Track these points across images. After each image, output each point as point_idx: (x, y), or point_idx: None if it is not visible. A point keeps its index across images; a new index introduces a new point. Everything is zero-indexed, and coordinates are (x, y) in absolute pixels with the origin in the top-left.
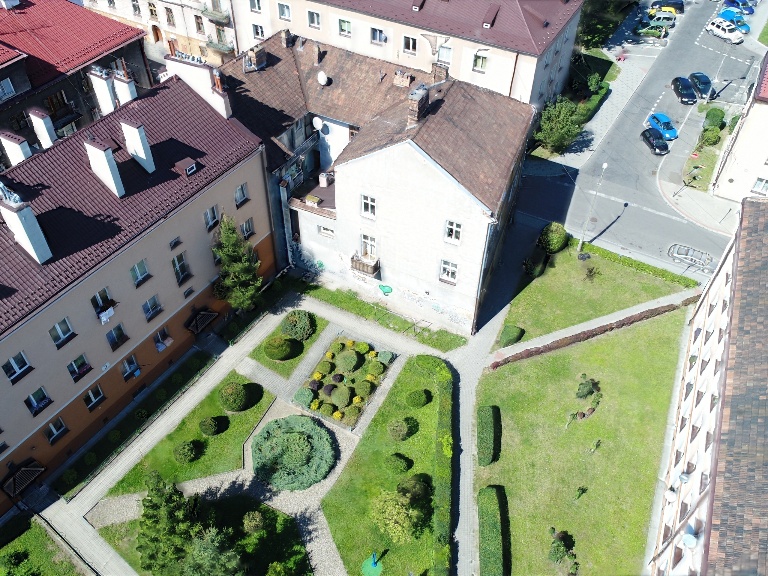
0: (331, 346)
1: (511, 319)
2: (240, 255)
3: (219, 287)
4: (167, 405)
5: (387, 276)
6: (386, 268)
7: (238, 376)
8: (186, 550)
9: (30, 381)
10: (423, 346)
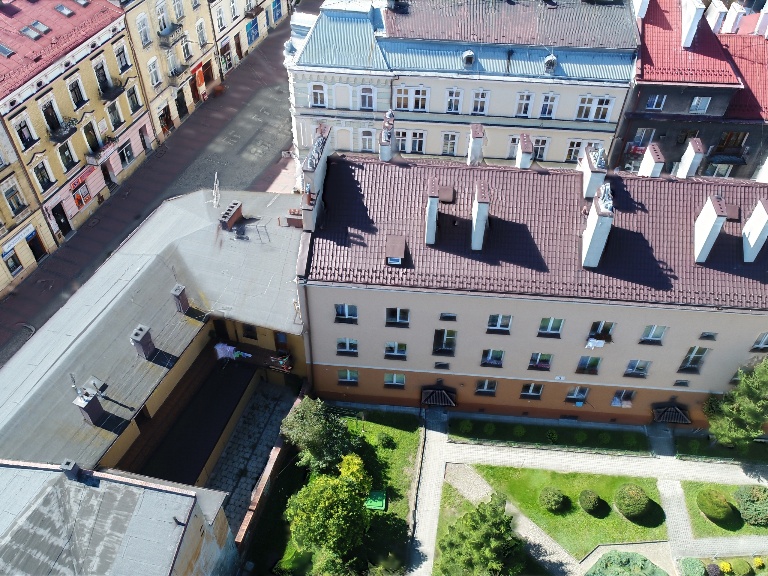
0: None
1: None
2: (761, 396)
3: (714, 402)
4: (577, 449)
5: None
6: None
7: (655, 488)
8: (475, 570)
9: (500, 340)
10: None
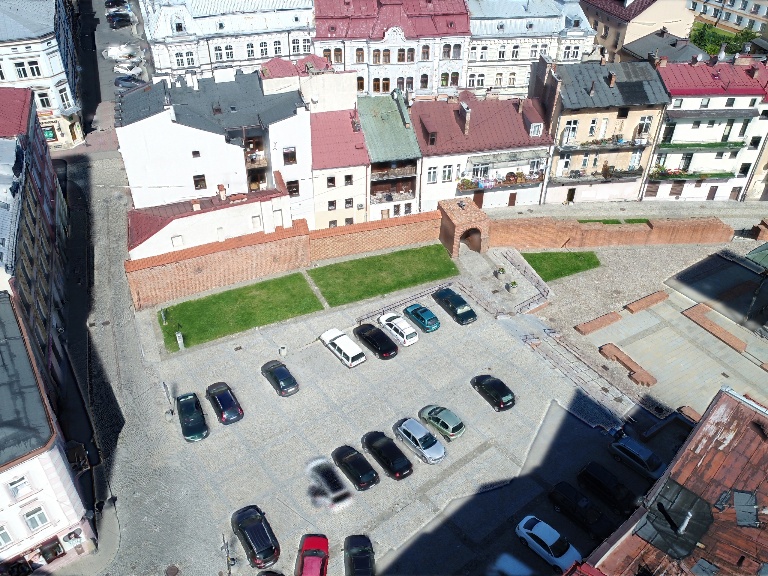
0: None
1: None
2: None
3: None
4: None
5: None
6: None
7: None
8: None
9: None
10: None
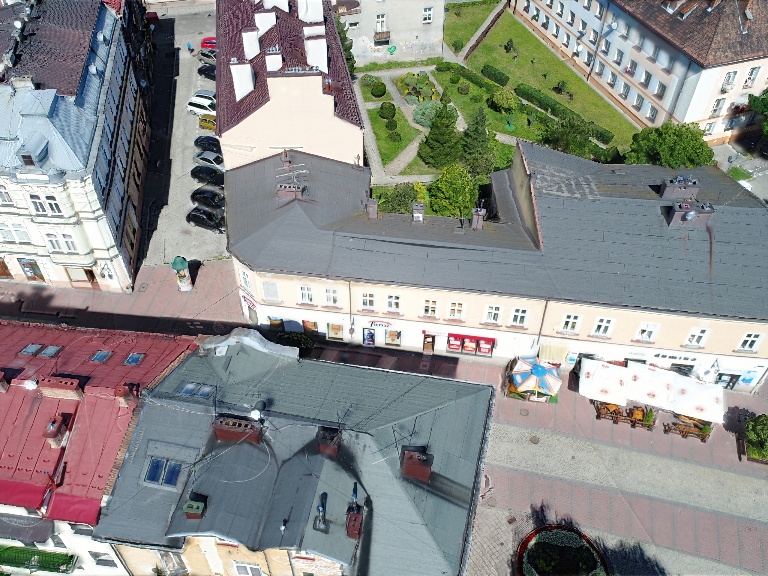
0: (396, 81)
1: (449, 43)
2: None
3: None
4: None
5: (393, 39)
6: (392, 33)
7: (372, 110)
8: None
9: None
10: (429, 67)
